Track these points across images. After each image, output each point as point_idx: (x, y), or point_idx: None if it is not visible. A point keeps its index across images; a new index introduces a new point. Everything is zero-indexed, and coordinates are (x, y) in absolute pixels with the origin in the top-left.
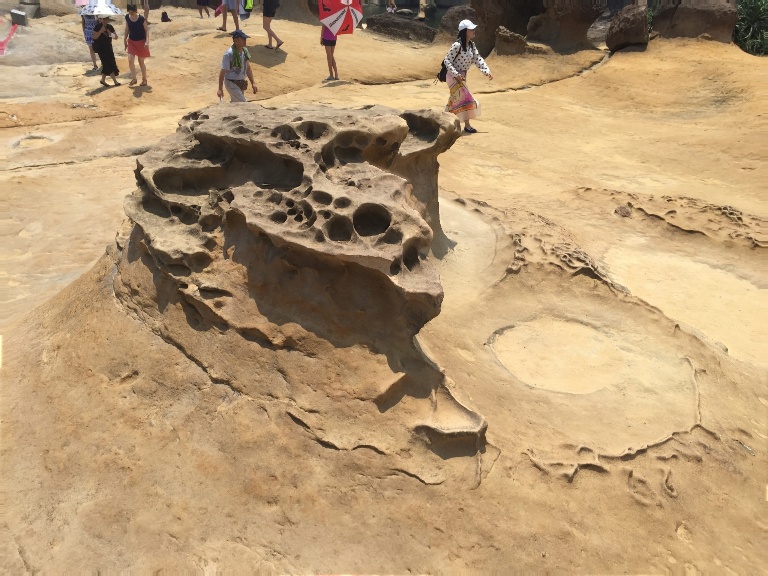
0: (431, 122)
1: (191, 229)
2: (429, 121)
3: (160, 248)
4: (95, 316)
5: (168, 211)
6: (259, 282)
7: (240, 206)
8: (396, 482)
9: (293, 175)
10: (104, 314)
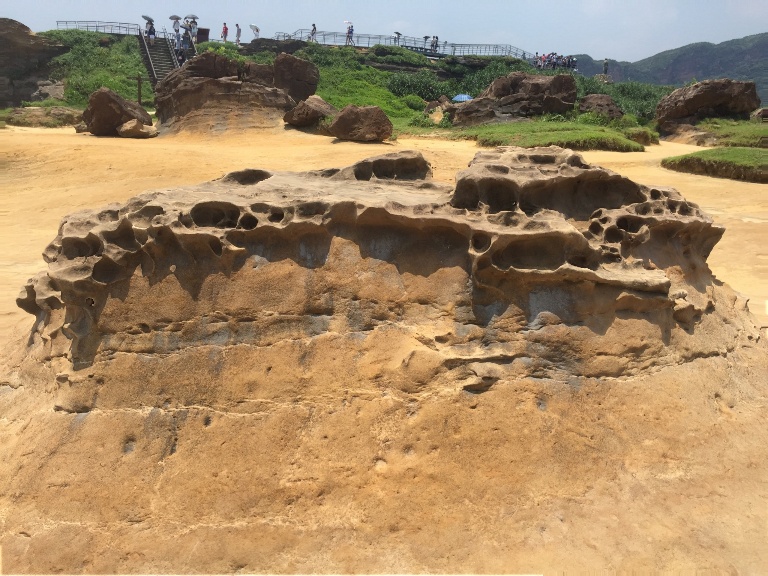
0: (417, 161)
1: (622, 265)
2: (413, 161)
3: (667, 279)
4: (634, 405)
5: (584, 265)
6: (689, 270)
7: (665, 217)
8: (766, 335)
9: (584, 199)
10: (639, 394)
